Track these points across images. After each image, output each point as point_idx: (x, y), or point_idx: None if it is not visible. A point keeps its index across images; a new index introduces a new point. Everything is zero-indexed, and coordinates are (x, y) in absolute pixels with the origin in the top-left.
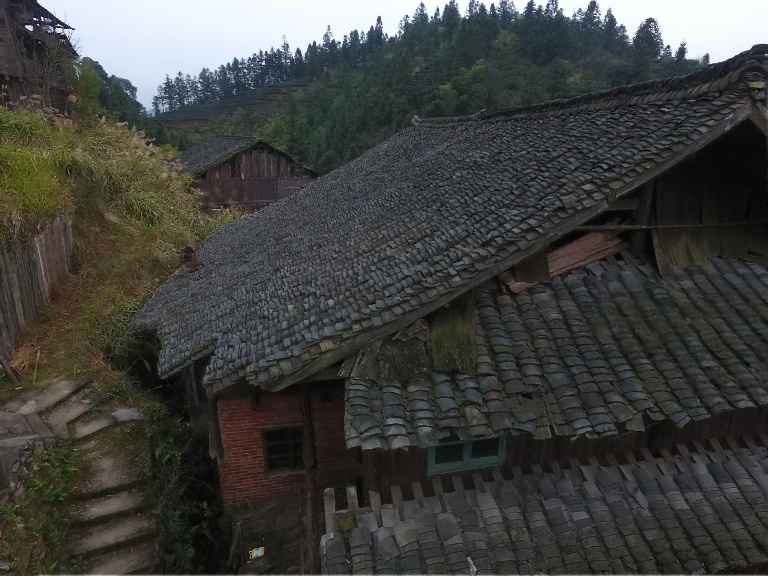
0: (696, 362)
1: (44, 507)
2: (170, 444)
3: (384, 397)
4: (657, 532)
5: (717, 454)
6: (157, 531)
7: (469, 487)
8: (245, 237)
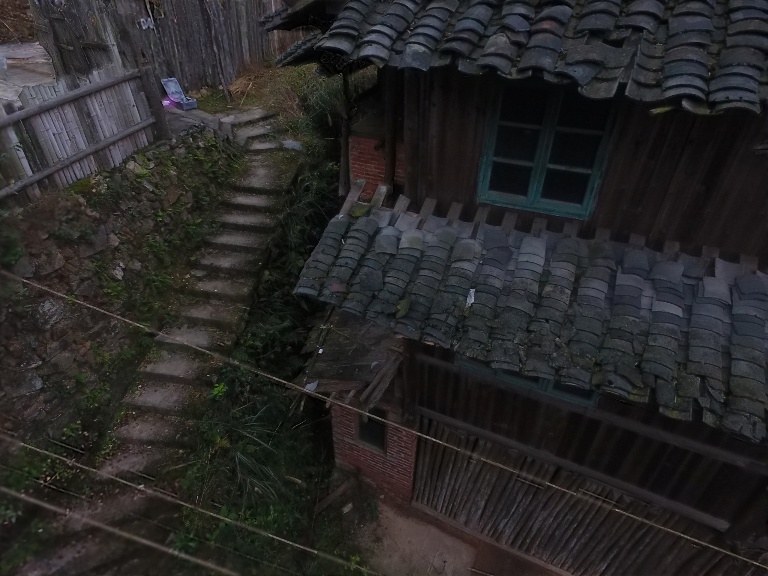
0: None
1: (202, 177)
2: (314, 176)
3: None
4: None
5: None
6: (274, 229)
7: (522, 229)
8: None
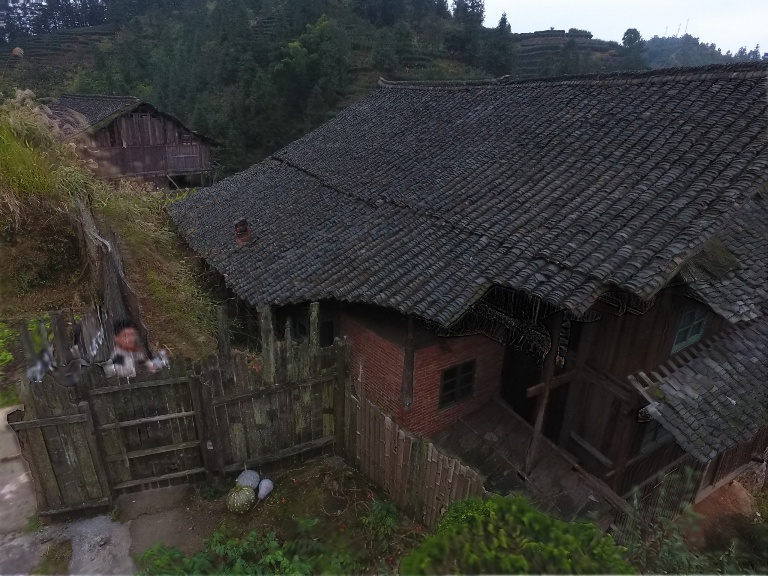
0: None
1: None
2: None
3: (720, 290)
4: None
5: None
6: None
7: (694, 357)
8: (277, 206)
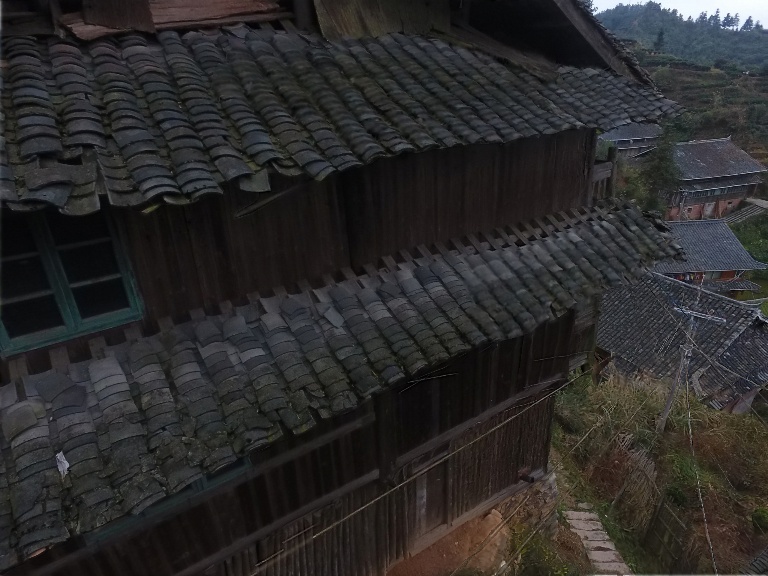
0: (354, 116)
1: None
2: None
3: None
4: (352, 349)
5: (424, 259)
6: None
7: (80, 358)
8: None
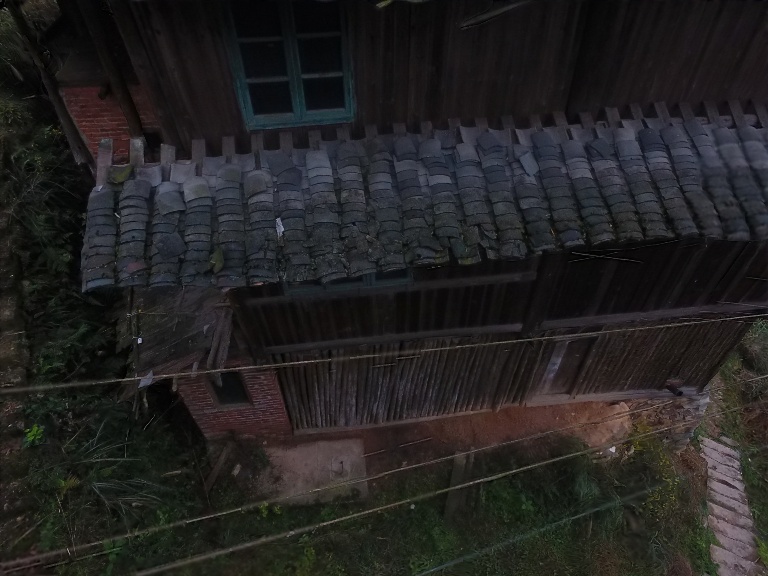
0: None
1: None
2: (31, 149)
3: None
4: (537, 201)
5: (658, 120)
6: (8, 229)
7: (301, 146)
8: None
